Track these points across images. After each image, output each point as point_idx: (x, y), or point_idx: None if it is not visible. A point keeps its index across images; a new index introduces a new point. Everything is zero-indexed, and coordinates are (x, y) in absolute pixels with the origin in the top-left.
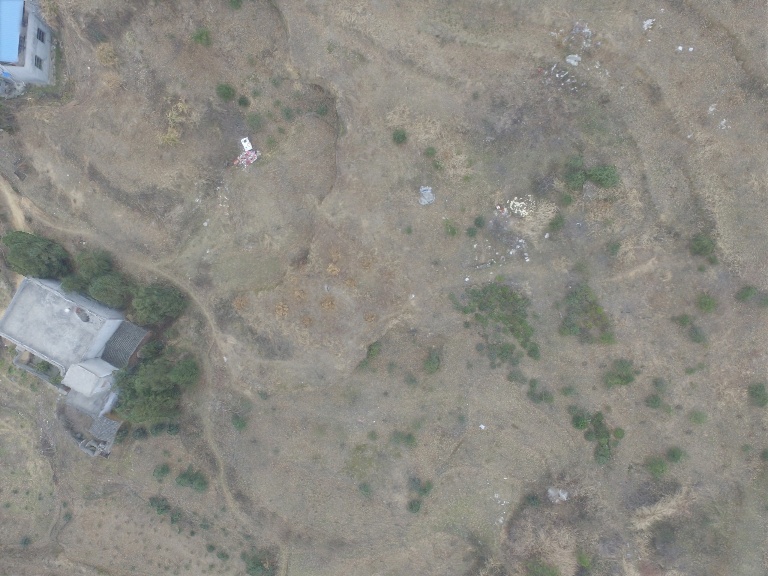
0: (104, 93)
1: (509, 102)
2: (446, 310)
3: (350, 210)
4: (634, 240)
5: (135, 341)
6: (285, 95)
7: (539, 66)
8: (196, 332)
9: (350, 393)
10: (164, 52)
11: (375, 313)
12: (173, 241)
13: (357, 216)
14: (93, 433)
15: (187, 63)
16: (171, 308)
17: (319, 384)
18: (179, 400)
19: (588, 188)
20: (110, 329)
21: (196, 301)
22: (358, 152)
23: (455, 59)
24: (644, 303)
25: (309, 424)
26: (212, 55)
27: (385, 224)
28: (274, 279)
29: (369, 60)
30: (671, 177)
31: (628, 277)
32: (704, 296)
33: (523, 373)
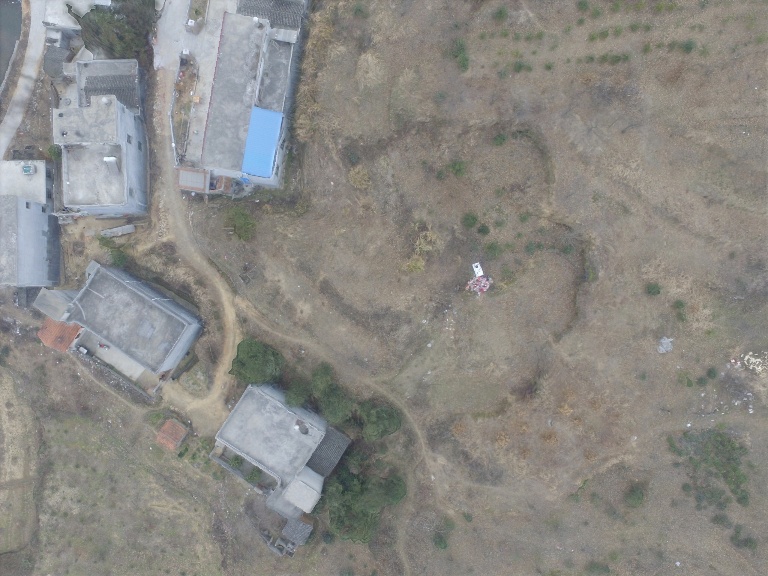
0: (350, 212)
1: (766, 266)
2: (662, 451)
3: (588, 352)
4: None
5: (340, 449)
6: (527, 228)
7: None
8: (404, 447)
9: (552, 521)
10: (414, 177)
11: (596, 451)
12: (395, 359)
13: (594, 359)
14: (287, 535)
15: (435, 190)
16: None
17: (528, 513)
18: (381, 513)
19: None
20: None
21: (409, 418)
22: (608, 300)
23: (719, 220)
24: None
25: (507, 547)
26: (460, 183)
27: (621, 369)
28: (492, 405)
29: (632, 213)
30: None
31: None
32: None
33: (729, 518)
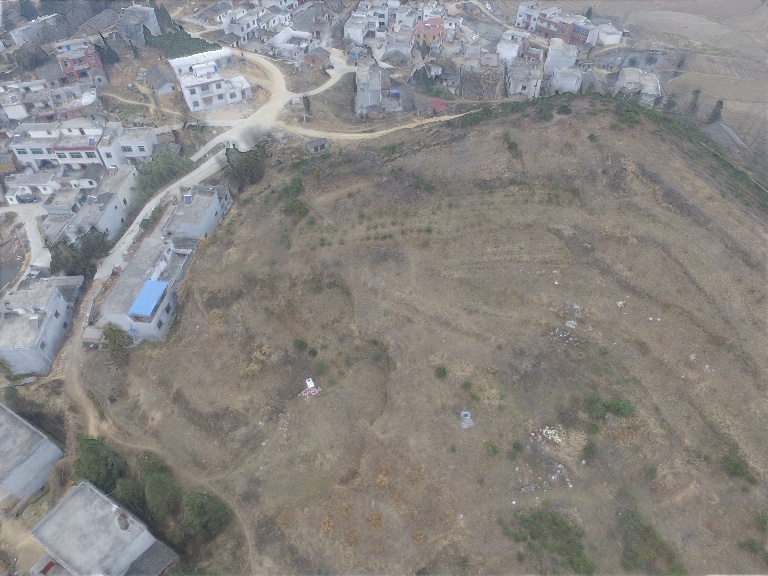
0: (206, 340)
1: (527, 352)
2: (497, 536)
3: (399, 430)
4: (668, 464)
5: (163, 563)
6: (346, 348)
7: (545, 329)
8: (231, 554)
9: None
10: (258, 318)
11: (423, 533)
12: (230, 458)
13: (405, 435)
14: None
15: (274, 325)
16: (216, 516)
17: None
18: None
19: (610, 418)
20: (142, 545)
21: (239, 518)
22: (406, 383)
23: (480, 323)
24: (702, 528)
25: None
26: (293, 321)
27: (431, 443)
28: (321, 497)
29: (414, 322)
30: (681, 408)
31: (676, 501)
32: (760, 516)
33: None
